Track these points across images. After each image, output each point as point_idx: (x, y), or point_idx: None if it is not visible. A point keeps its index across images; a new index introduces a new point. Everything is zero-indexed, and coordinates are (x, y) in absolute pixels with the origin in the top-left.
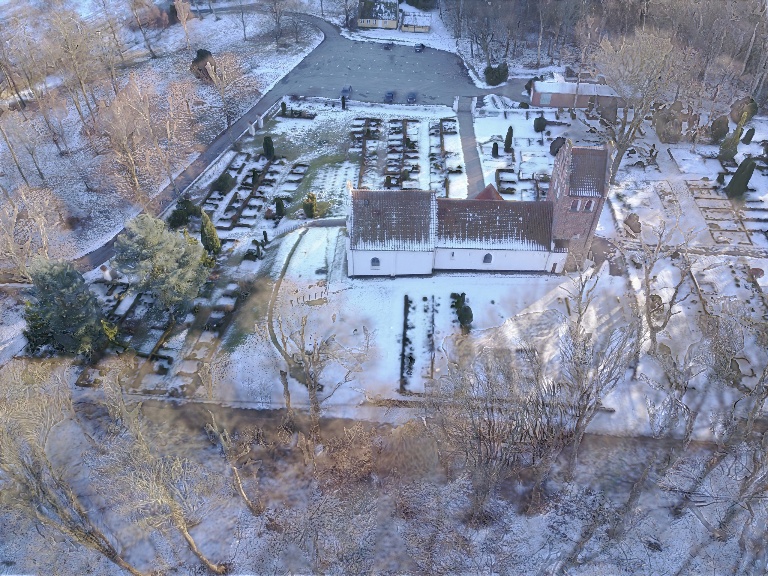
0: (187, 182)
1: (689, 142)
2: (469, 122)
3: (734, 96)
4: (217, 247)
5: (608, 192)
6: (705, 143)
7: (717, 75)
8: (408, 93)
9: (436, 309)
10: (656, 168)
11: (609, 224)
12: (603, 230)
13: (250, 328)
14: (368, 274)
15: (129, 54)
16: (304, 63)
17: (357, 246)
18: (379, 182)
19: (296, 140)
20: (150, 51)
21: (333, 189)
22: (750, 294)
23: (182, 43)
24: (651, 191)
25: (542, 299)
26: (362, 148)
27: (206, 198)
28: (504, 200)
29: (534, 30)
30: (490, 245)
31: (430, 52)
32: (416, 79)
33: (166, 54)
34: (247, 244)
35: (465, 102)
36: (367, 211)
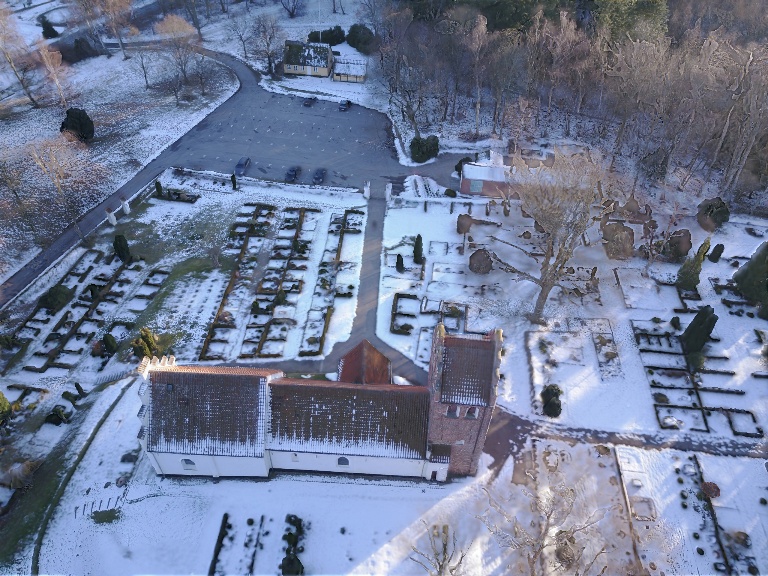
0: (12, 293)
1: (642, 258)
2: (380, 215)
3: (707, 181)
4: (2, 412)
5: (495, 401)
6: (662, 260)
7: (689, 150)
8: (317, 169)
9: (261, 542)
10: (596, 299)
11: (524, 391)
12: (514, 401)
13: (8, 554)
14: (183, 473)
15: (13, 100)
16: (205, 122)
17: (157, 447)
18: (247, 305)
19: (165, 233)
20: (31, 100)
21: (187, 314)
22: (700, 520)
23: (77, 88)
24: (586, 336)
25: (412, 526)
26: (241, 250)
27: (27, 320)
28: (363, 387)
29: (484, 84)
30: (343, 448)
31: (357, 111)
32: (331, 149)
33: (53, 102)
34: (57, 396)
35: (381, 185)
36: (171, 399)
